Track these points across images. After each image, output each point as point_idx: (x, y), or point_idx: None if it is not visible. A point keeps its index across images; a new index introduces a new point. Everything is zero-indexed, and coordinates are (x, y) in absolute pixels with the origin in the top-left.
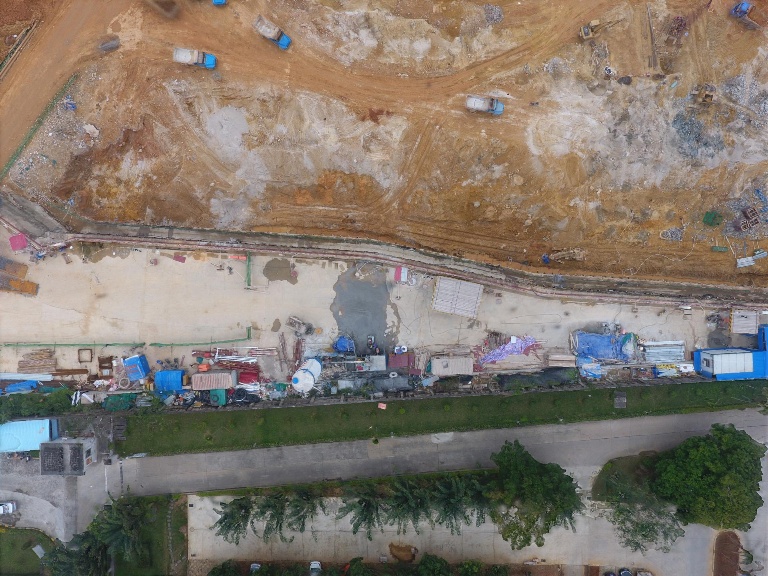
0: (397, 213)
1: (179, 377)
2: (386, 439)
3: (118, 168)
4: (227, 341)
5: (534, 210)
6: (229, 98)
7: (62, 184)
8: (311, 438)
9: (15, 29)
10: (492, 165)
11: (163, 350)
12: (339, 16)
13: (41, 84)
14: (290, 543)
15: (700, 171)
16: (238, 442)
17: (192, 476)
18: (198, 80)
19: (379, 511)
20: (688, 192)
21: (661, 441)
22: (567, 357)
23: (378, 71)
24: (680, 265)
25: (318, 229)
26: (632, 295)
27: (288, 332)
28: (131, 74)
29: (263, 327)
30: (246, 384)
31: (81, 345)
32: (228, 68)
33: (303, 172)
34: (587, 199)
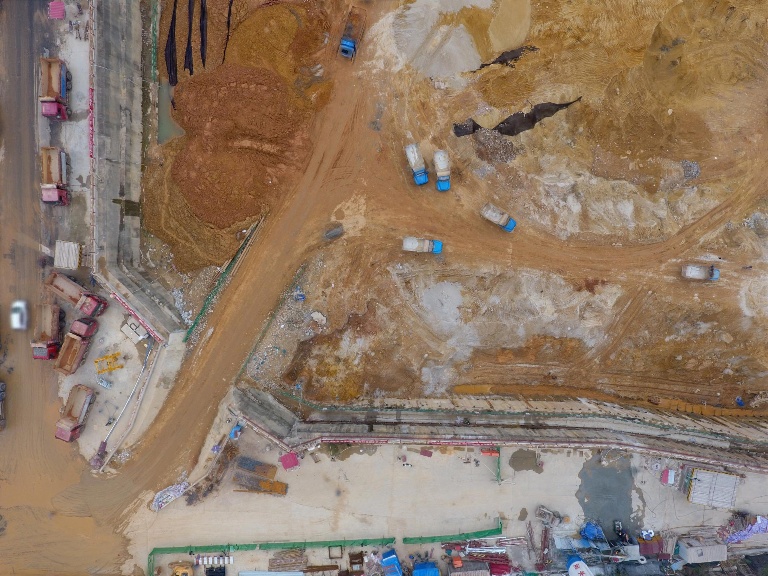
0: (598, 368)
1: (437, 575)
2: None
3: (337, 347)
4: (480, 536)
5: (735, 360)
6: (447, 275)
7: (288, 369)
8: None
9: (245, 225)
10: (697, 322)
11: None
12: (549, 187)
13: (271, 277)
14: None
15: None
16: None
17: None
18: (421, 263)
19: None
20: None
21: None
22: None
23: (593, 242)
24: None
25: (519, 385)
26: None
27: (535, 520)
28: (356, 260)
29: (510, 516)
30: None
31: (332, 543)
32: (451, 250)
33: (514, 338)
34: None
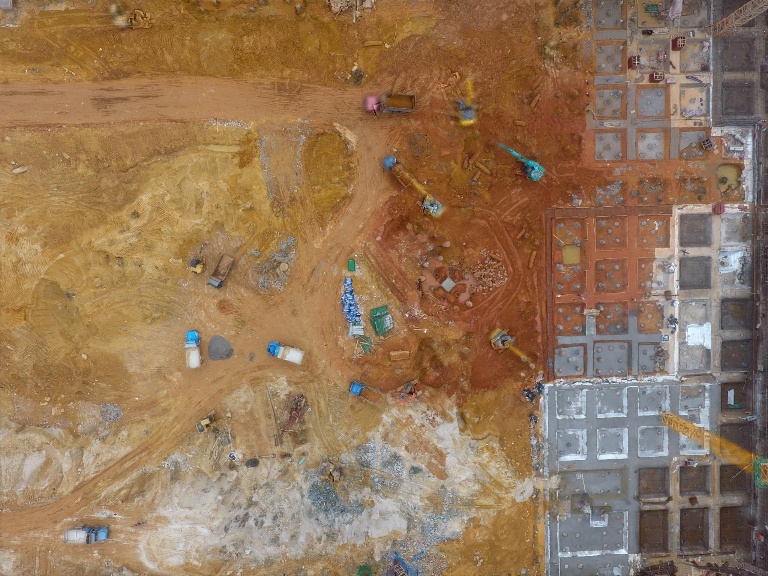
0: None
1: None
2: None
3: None
4: None
5: None
6: None
7: None
8: None
9: None
10: (123, 567)
11: None
12: None
13: None
14: None
15: (333, 546)
16: None
17: None
18: None
19: None
20: None
21: None
22: None
23: None
24: None
25: None
26: None
27: None
28: None
29: None
30: None
31: None
32: None
33: None
34: None
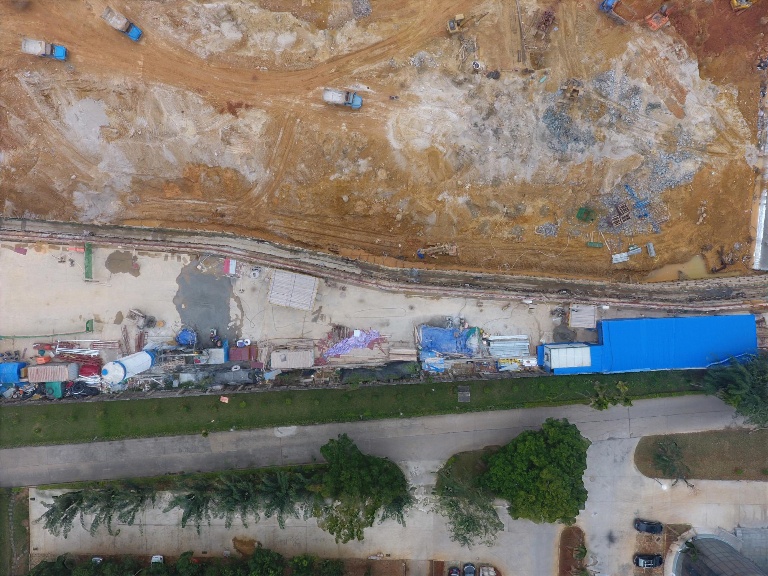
0: (267, 207)
1: (15, 369)
2: (229, 433)
3: None
4: None
5: (403, 205)
6: (85, 90)
7: None
8: (153, 431)
9: None
10: (358, 159)
11: (4, 342)
12: (199, 8)
13: None
14: (133, 537)
15: (568, 166)
16: (79, 435)
17: (33, 469)
18: (51, 72)
19: (210, 505)
20: (559, 187)
21: (505, 436)
22: (408, 351)
23: (236, 64)
24: (556, 261)
25: (188, 223)
26: (477, 289)
27: (131, 325)
28: None
29: (105, 320)
30: (86, 377)
31: None
32: (81, 60)
33: (166, 165)
34: (455, 194)
